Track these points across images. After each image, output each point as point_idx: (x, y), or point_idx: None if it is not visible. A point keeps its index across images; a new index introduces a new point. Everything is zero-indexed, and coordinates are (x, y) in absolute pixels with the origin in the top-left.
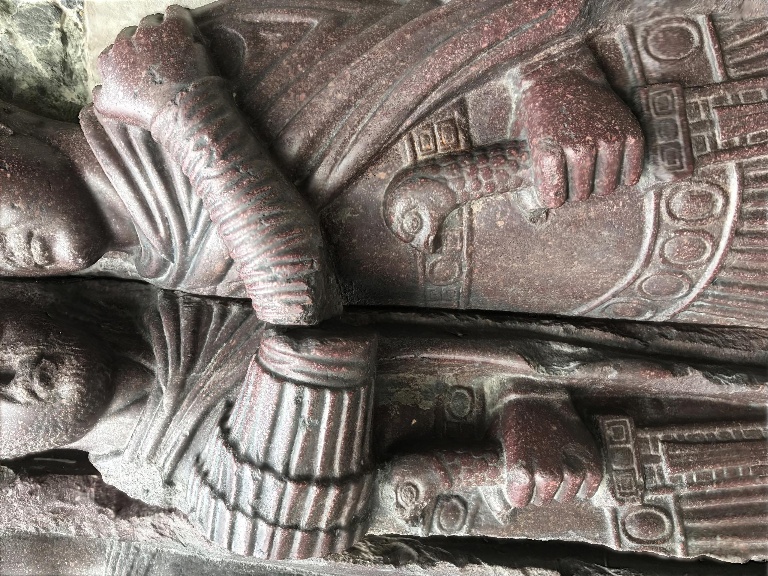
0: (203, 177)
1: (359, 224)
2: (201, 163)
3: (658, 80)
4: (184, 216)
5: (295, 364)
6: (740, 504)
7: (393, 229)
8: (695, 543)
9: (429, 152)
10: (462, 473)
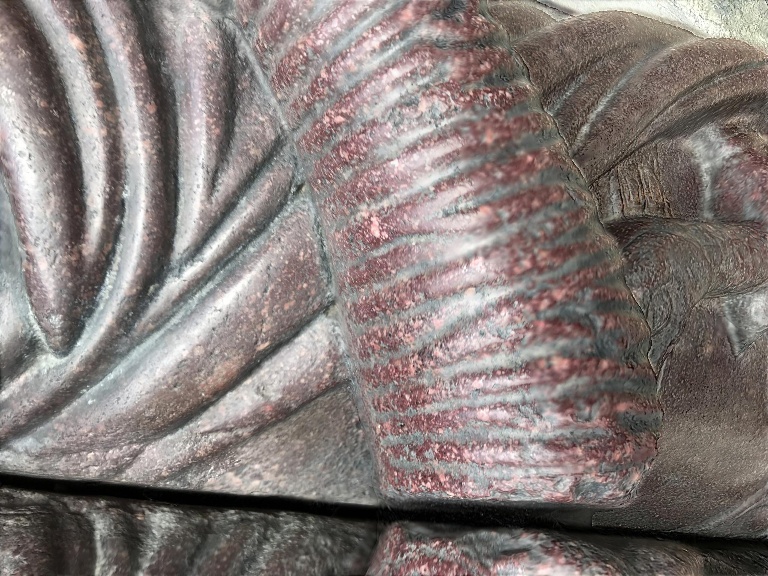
0: (422, 41)
1: None
2: (426, 3)
3: None
4: (179, 208)
5: None
6: None
7: None
8: None
9: (637, 207)
10: None
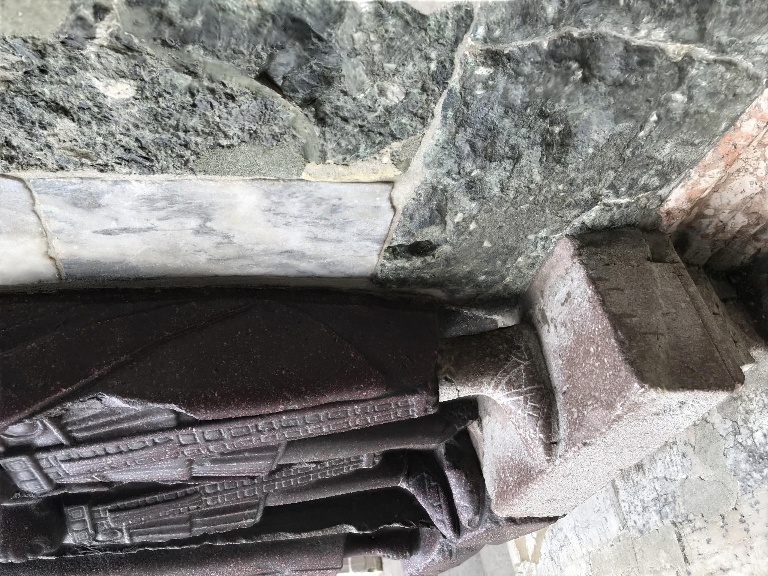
0: None
1: None
2: None
3: (16, 443)
4: None
5: None
6: (165, 519)
7: None
8: (137, 537)
9: None
10: None
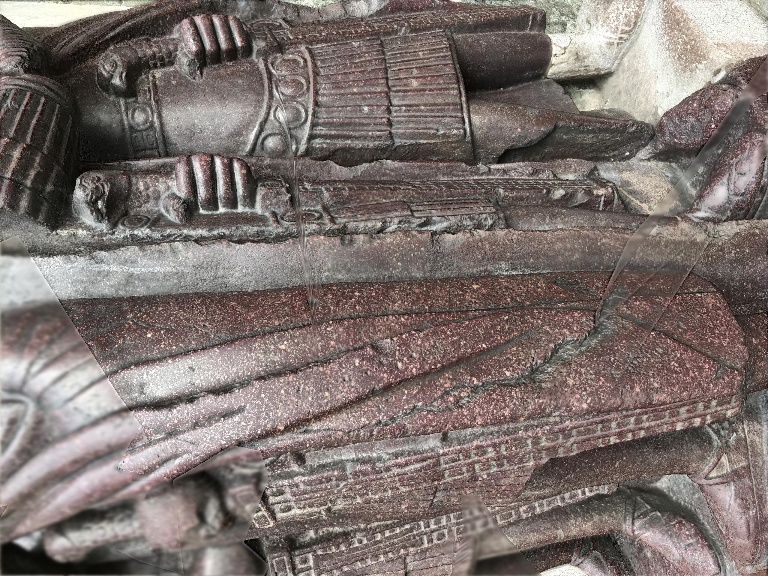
0: None
1: (81, 88)
2: None
3: None
4: None
5: (9, 81)
6: None
7: (99, 73)
8: (341, 221)
9: None
10: (139, 175)
